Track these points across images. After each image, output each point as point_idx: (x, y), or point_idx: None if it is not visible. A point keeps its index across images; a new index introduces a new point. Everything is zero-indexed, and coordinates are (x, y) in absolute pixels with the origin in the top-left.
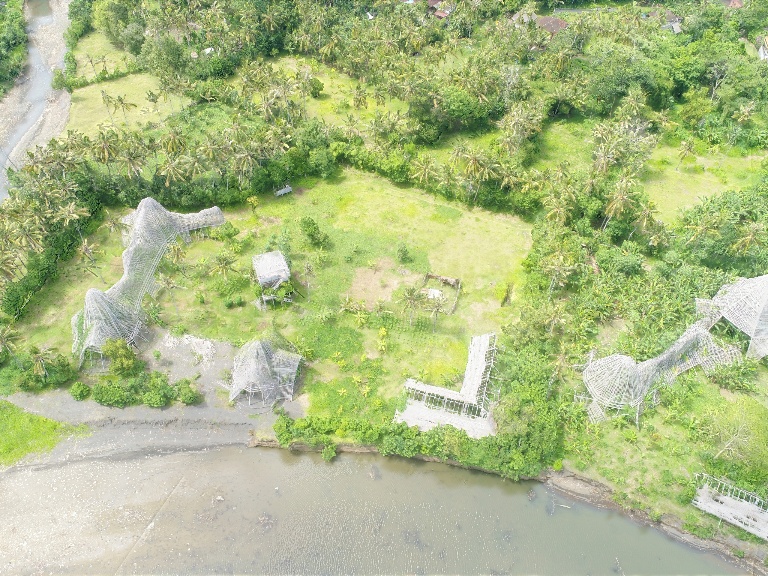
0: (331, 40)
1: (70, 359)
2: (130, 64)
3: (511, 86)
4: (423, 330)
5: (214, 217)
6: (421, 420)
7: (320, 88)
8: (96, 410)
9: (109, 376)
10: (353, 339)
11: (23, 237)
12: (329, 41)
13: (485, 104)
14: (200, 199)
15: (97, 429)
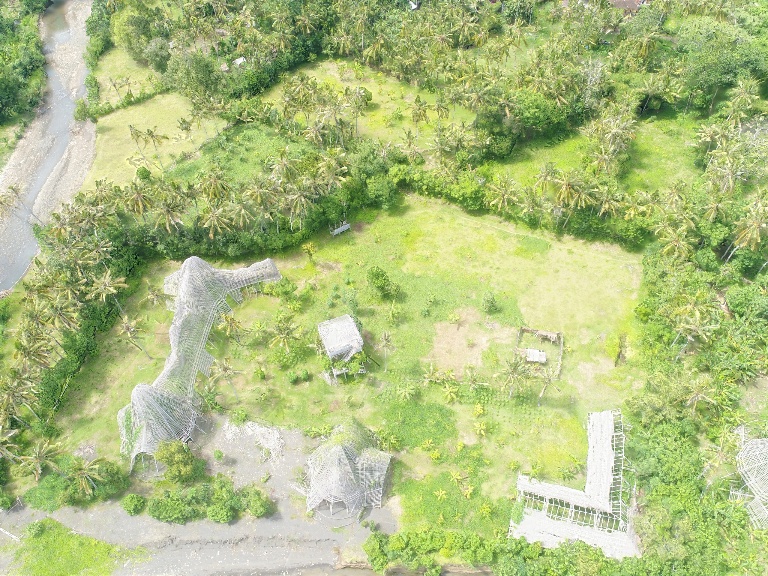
0: (376, 40)
1: (119, 460)
2: (156, 84)
3: (592, 83)
4: (526, 403)
5: (267, 271)
6: (543, 533)
7: (368, 98)
8: (154, 527)
9: (165, 481)
10: (444, 419)
11: (56, 317)
12: (374, 41)
13: (564, 107)
14: (248, 247)
15: (157, 551)
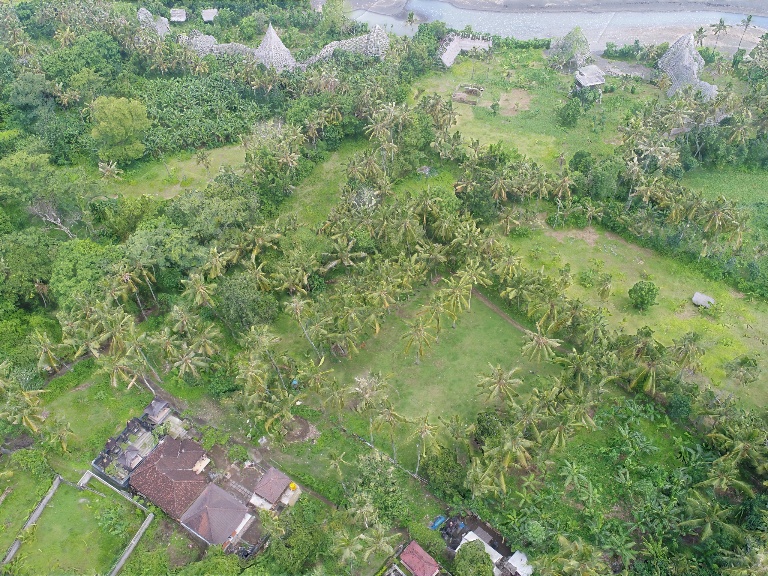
0: None
1: None
2: None
3: None
4: None
5: None
6: None
7: None
8: None
9: None
10: None
11: None
12: None
13: None
14: None
15: None
